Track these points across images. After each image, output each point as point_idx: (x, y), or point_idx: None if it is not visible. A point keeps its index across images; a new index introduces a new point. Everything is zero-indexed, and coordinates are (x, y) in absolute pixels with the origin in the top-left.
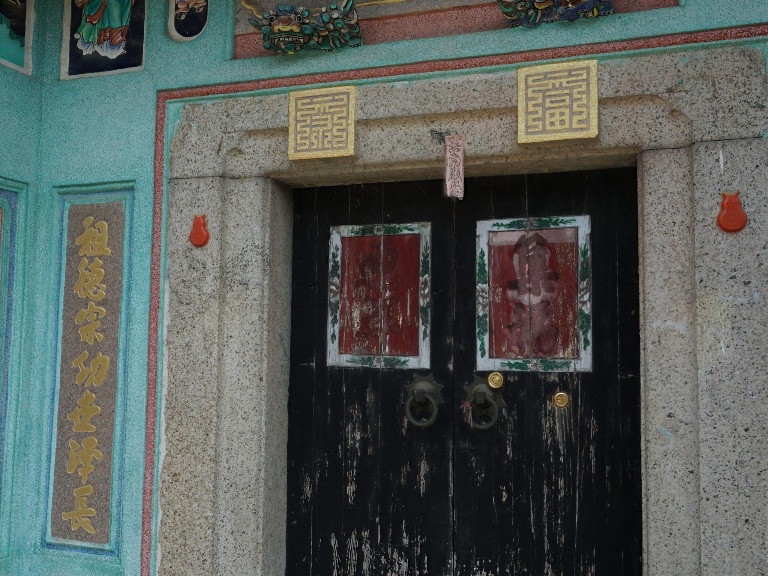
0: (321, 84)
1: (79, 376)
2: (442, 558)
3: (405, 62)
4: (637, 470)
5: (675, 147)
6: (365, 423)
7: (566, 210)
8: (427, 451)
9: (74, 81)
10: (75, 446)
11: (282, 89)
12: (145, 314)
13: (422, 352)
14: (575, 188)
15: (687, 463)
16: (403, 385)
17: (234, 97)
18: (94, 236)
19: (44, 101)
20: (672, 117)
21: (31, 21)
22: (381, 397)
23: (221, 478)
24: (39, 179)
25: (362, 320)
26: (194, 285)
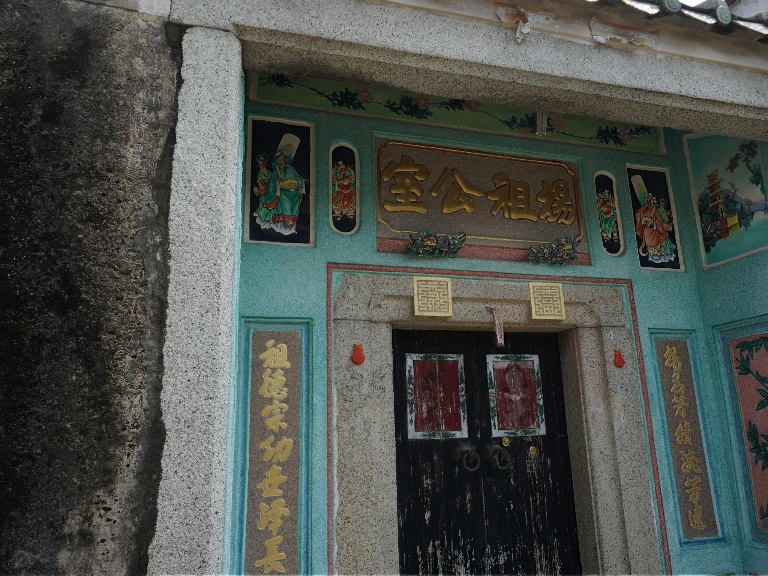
0: (433, 275)
1: (266, 455)
2: (482, 549)
3: (479, 270)
4: (570, 484)
5: (590, 327)
6: (434, 473)
7: (528, 352)
8: (470, 486)
9: (259, 245)
10: (265, 508)
11: (410, 274)
12: (325, 408)
13: (463, 428)
14: (531, 341)
15: (610, 475)
16: (454, 448)
17: (378, 274)
18: (275, 354)
19: None
20: (590, 314)
21: None
22: (442, 456)
23: None
24: None
25: (428, 410)
26: (355, 389)
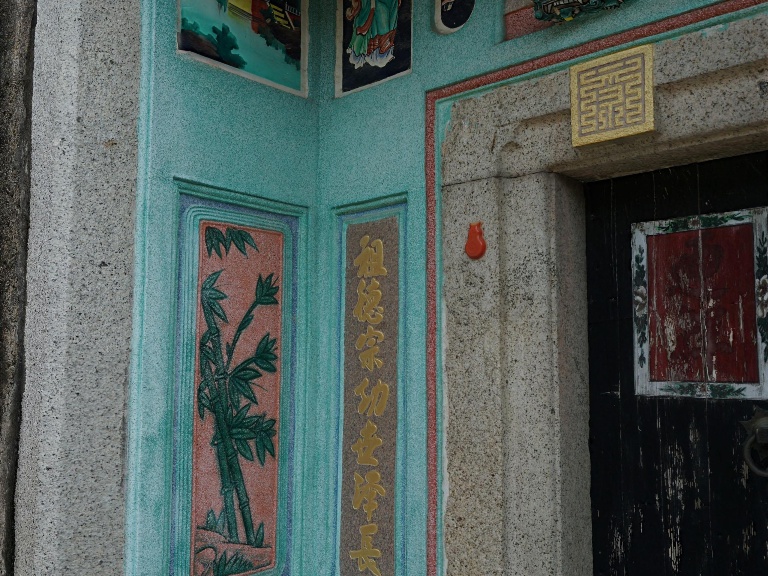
0: (608, 50)
1: (361, 405)
2: None
3: None
4: None
5: None
6: (689, 468)
7: None
8: None
9: (347, 97)
10: (359, 480)
11: (561, 65)
12: (422, 337)
13: (764, 377)
14: None
15: None
16: (739, 421)
17: (507, 84)
18: (371, 256)
19: (321, 122)
20: None
21: (306, 44)
22: (709, 436)
23: (511, 527)
24: (318, 202)
25: (678, 337)
26: (472, 303)
